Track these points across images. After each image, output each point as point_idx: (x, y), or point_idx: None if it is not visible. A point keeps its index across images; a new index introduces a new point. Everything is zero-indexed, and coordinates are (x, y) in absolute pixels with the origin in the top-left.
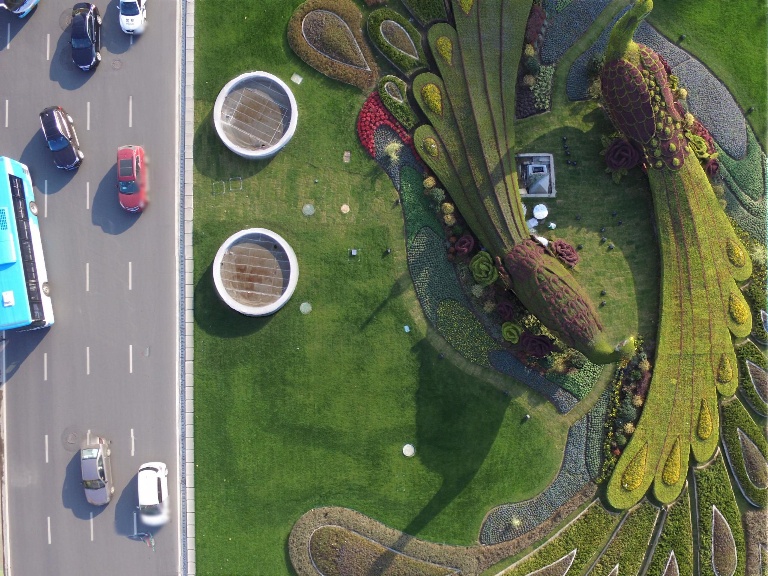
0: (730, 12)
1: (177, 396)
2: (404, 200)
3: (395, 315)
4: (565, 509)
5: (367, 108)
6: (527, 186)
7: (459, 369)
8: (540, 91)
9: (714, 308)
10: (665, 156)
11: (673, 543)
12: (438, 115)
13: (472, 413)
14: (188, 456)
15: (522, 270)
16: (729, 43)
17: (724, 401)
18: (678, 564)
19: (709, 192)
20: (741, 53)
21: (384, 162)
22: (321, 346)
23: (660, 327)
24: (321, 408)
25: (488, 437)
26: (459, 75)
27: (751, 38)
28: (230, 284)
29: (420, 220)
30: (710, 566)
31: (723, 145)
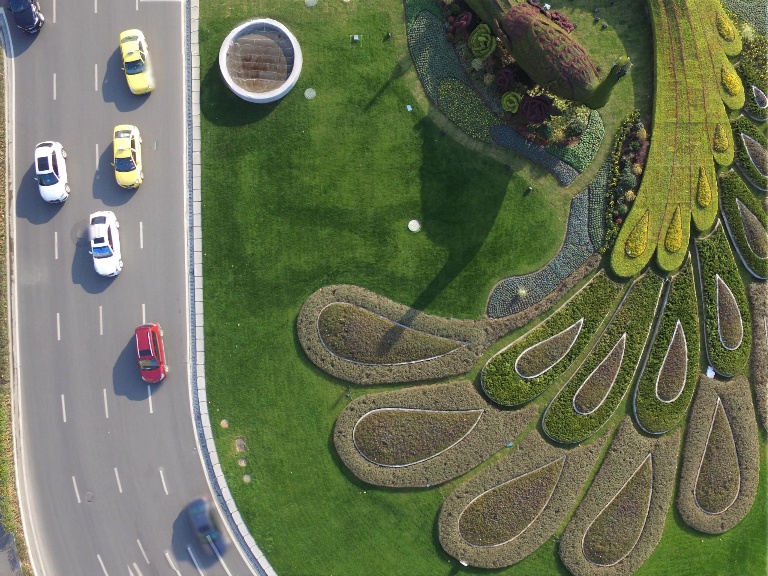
0: None
1: (185, 186)
2: None
3: (397, 95)
4: (570, 279)
5: None
6: None
7: (461, 145)
8: None
9: (707, 79)
10: None
11: (679, 312)
12: None
13: (475, 187)
14: (196, 245)
15: (519, 27)
16: None
17: (722, 174)
18: (685, 333)
19: None
20: None
21: None
22: (326, 129)
23: (655, 97)
24: (327, 188)
25: (492, 210)
26: None
27: None
28: (236, 74)
29: (419, 4)
30: (717, 336)
31: None
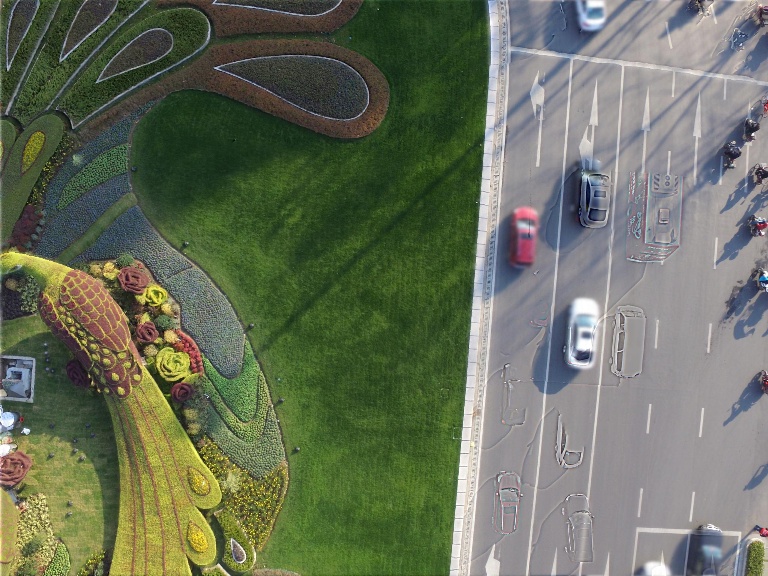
0: (244, 218)
1: None
2: None
3: None
4: None
5: None
6: None
7: None
8: (28, 294)
9: (169, 535)
10: (110, 384)
11: None
12: None
13: None
14: None
15: None
16: (238, 252)
17: None
18: None
19: (167, 420)
20: (250, 263)
21: None
22: None
23: (114, 547)
24: None
25: None
26: None
27: (264, 247)
28: None
29: None
30: None
31: (214, 362)
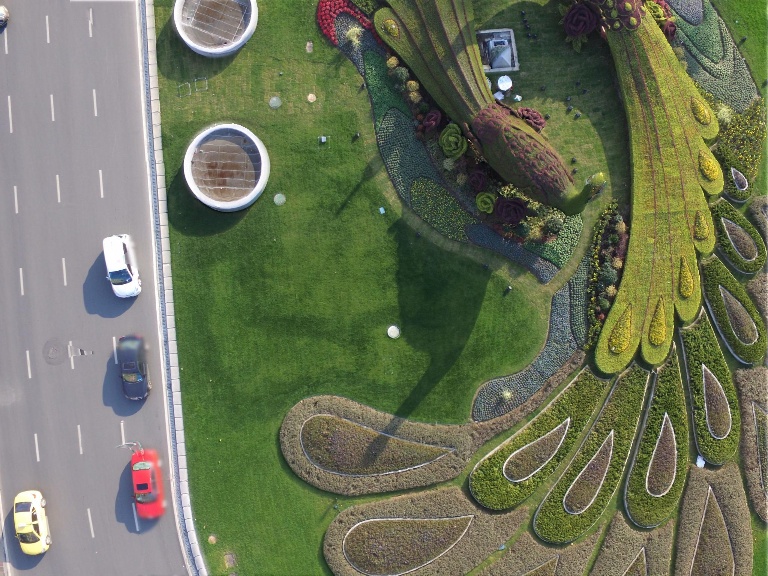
0: None
1: (157, 300)
2: (369, 84)
3: (369, 198)
4: (555, 378)
5: None
6: (490, 61)
7: (437, 246)
8: None
9: (684, 166)
10: (622, 16)
11: (666, 404)
12: None
13: (454, 289)
14: (172, 360)
15: (490, 131)
16: None
17: (703, 260)
18: (673, 426)
19: (669, 51)
20: None
21: (347, 49)
22: (298, 235)
23: (633, 188)
24: (302, 297)
25: (472, 312)
26: None
27: None
28: (202, 182)
29: (387, 102)
30: (705, 426)
31: (679, 11)
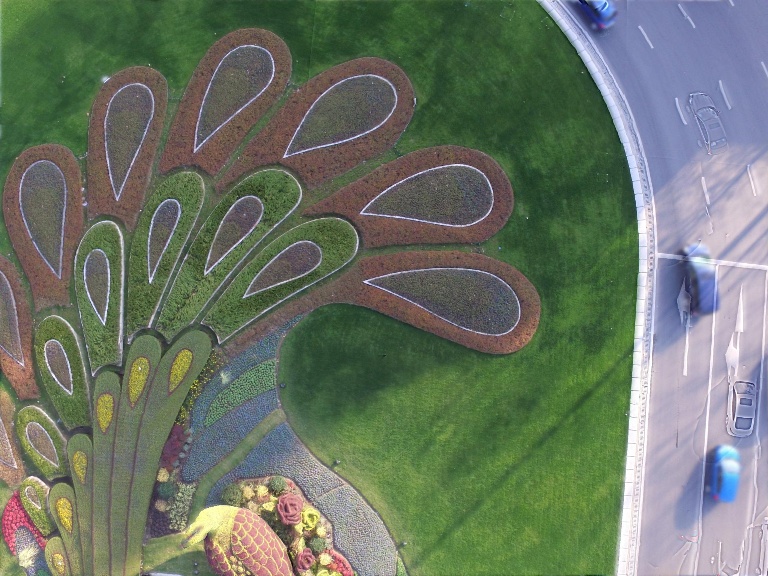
0: (396, 435)
1: None
2: None
3: None
4: None
5: (10, 507)
6: None
7: None
8: (176, 512)
9: None
10: None
11: None
12: (68, 532)
13: None
14: None
15: None
16: (390, 469)
17: None
18: None
19: None
20: (402, 481)
21: None
22: None
23: None
24: None
25: None
26: (88, 497)
27: (416, 465)
28: None
29: None
30: None
31: None
